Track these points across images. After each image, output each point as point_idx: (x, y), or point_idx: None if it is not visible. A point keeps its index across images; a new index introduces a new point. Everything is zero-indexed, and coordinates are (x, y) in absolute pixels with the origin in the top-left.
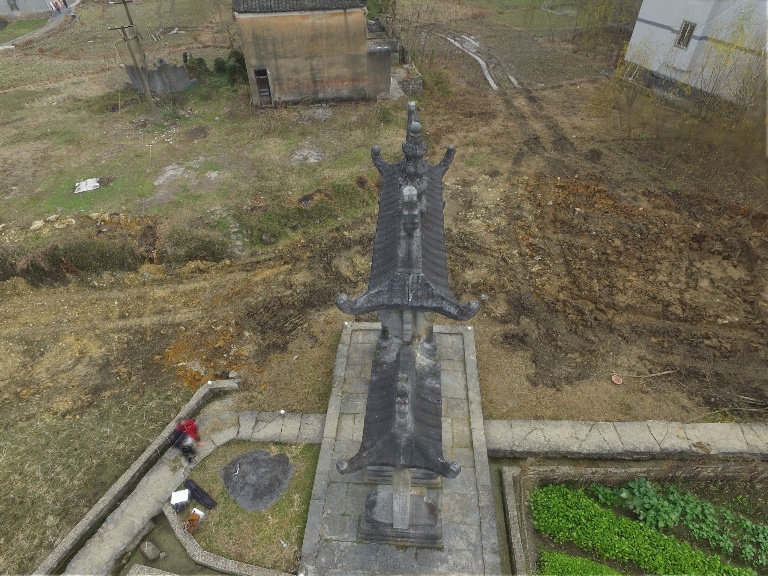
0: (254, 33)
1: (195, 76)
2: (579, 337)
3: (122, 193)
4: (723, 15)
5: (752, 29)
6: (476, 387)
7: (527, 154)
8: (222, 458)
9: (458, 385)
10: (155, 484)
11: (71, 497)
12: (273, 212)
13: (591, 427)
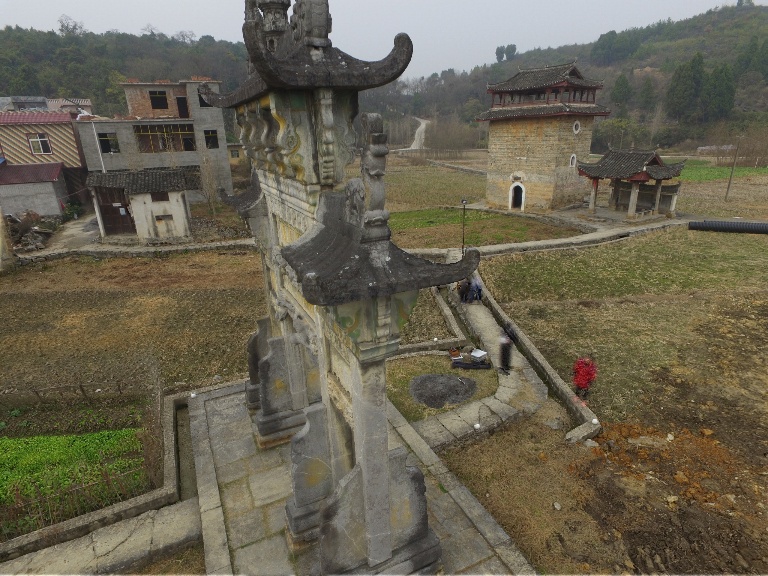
0: None
1: None
2: None
3: None
4: None
5: None
6: None
7: None
8: (486, 385)
9: (252, 570)
10: (510, 358)
11: (559, 347)
12: None
13: None
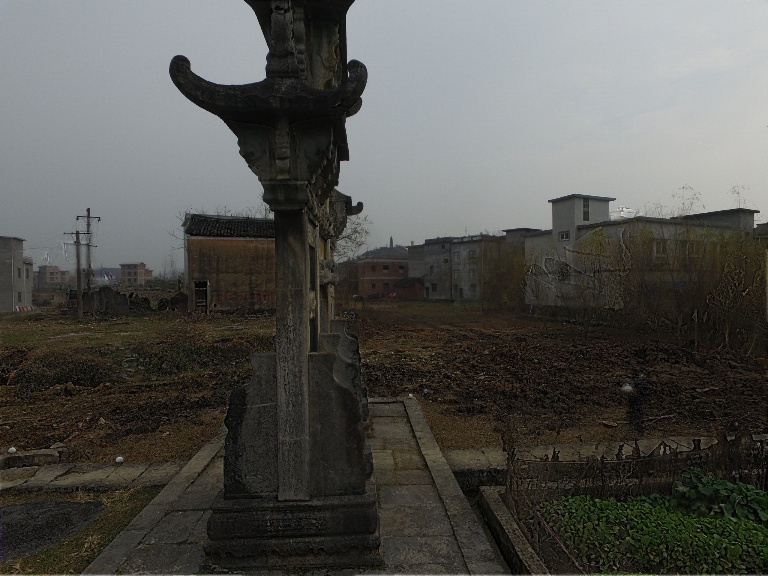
0: (201, 252)
1: (136, 308)
2: (549, 408)
3: (5, 341)
4: (583, 238)
5: (608, 242)
6: (425, 429)
7: (457, 340)
8: None
9: (400, 430)
10: None
11: None
12: (182, 346)
13: (596, 445)
